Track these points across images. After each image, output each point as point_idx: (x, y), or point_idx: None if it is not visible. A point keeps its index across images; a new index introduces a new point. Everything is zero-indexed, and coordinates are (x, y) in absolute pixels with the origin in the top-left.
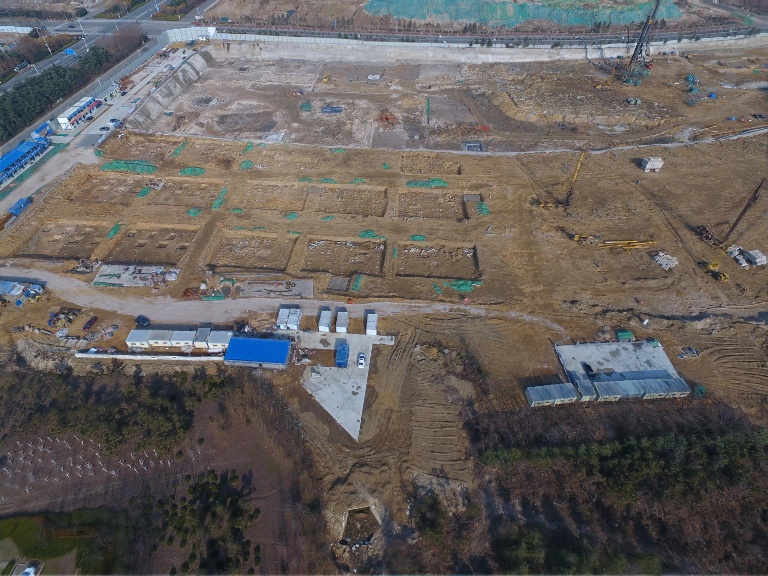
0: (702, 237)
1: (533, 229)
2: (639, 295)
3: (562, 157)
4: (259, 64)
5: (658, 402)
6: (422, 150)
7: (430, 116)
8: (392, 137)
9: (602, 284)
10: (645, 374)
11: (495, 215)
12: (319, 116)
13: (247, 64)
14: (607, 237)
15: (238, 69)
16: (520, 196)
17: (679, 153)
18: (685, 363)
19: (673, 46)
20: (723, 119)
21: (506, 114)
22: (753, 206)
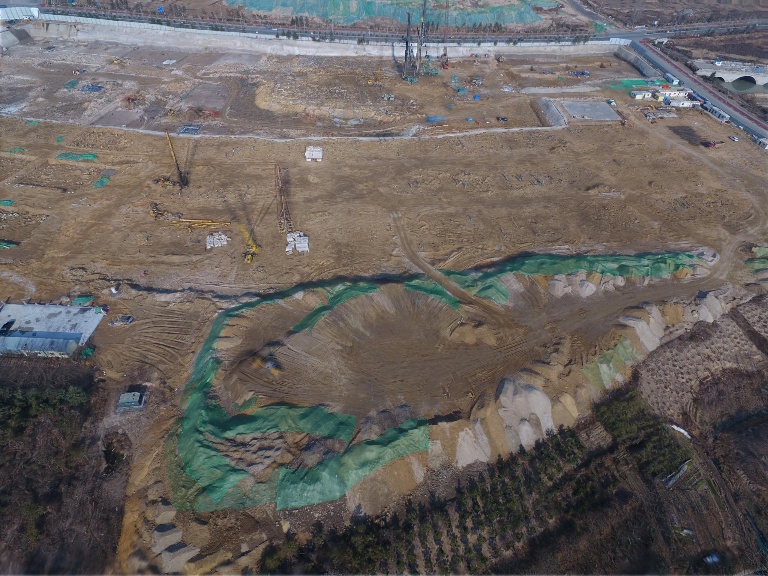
0: (278, 222)
1: (125, 203)
2: (153, 268)
3: (242, 142)
4: (71, 44)
5: (37, 360)
6: (112, 127)
7: (182, 100)
8: (122, 116)
9: (129, 256)
10: (57, 335)
11: (106, 188)
12: (73, 93)
13: (60, 44)
14: (190, 216)
15: (46, 47)
16: (153, 174)
17: (364, 146)
18: (108, 329)
19: (489, 49)
20: (462, 119)
21: (255, 102)
22: (373, 199)
